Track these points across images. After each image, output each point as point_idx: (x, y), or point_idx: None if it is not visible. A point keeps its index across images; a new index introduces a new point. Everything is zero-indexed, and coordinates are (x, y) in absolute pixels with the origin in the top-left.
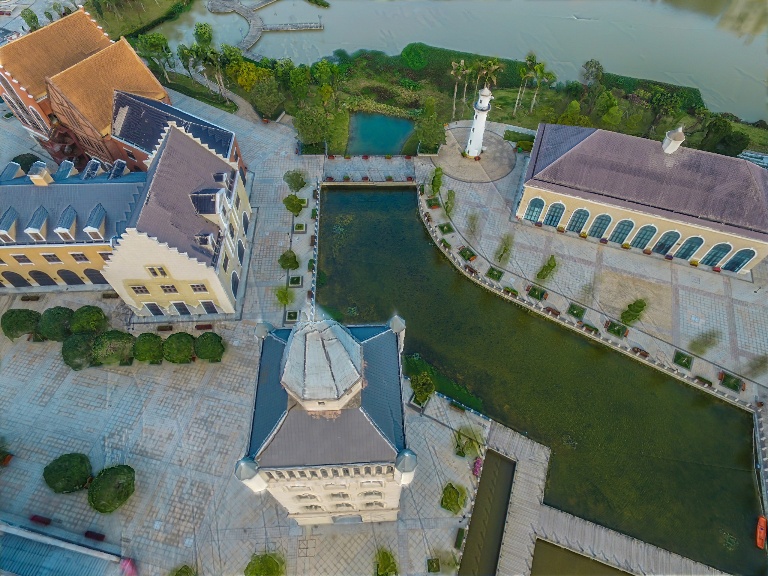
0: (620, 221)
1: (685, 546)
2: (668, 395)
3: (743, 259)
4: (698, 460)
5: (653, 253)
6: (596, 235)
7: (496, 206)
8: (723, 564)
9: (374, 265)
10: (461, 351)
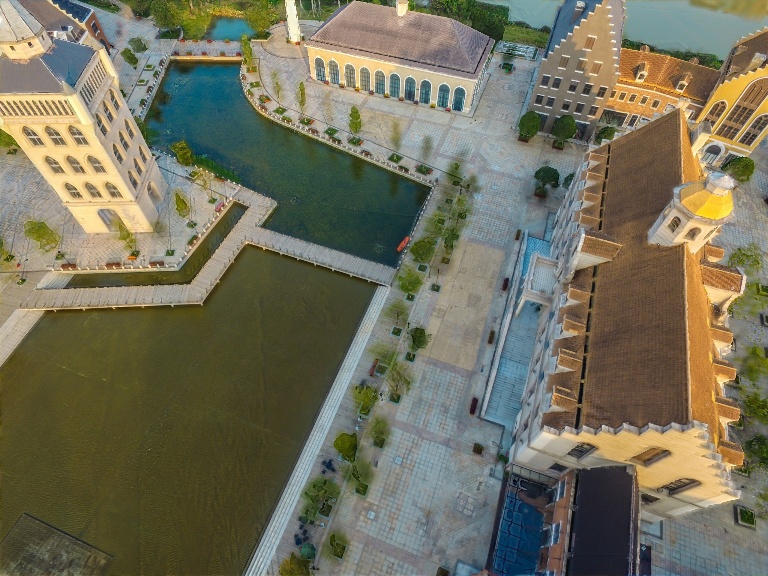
0: (375, 72)
1: (349, 251)
2: (378, 178)
3: (461, 98)
4: (381, 211)
5: (406, 100)
6: (367, 89)
7: (300, 72)
8: (370, 259)
9: (194, 107)
10: (239, 154)
